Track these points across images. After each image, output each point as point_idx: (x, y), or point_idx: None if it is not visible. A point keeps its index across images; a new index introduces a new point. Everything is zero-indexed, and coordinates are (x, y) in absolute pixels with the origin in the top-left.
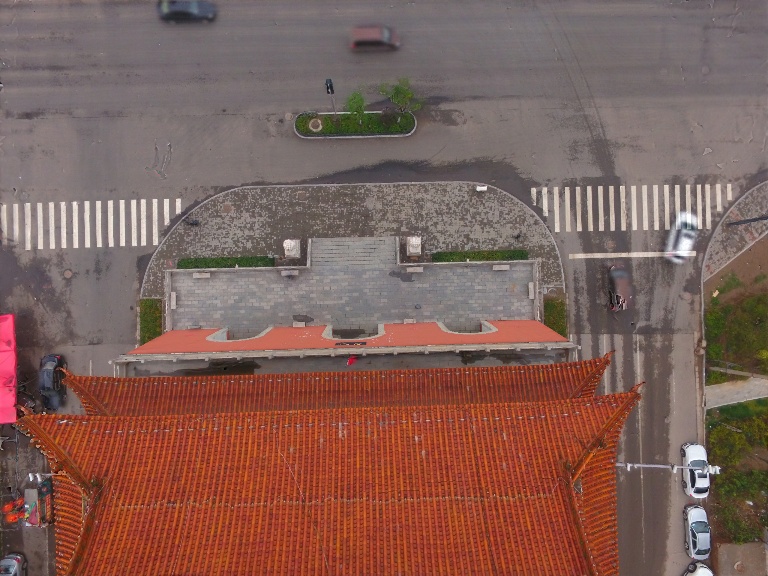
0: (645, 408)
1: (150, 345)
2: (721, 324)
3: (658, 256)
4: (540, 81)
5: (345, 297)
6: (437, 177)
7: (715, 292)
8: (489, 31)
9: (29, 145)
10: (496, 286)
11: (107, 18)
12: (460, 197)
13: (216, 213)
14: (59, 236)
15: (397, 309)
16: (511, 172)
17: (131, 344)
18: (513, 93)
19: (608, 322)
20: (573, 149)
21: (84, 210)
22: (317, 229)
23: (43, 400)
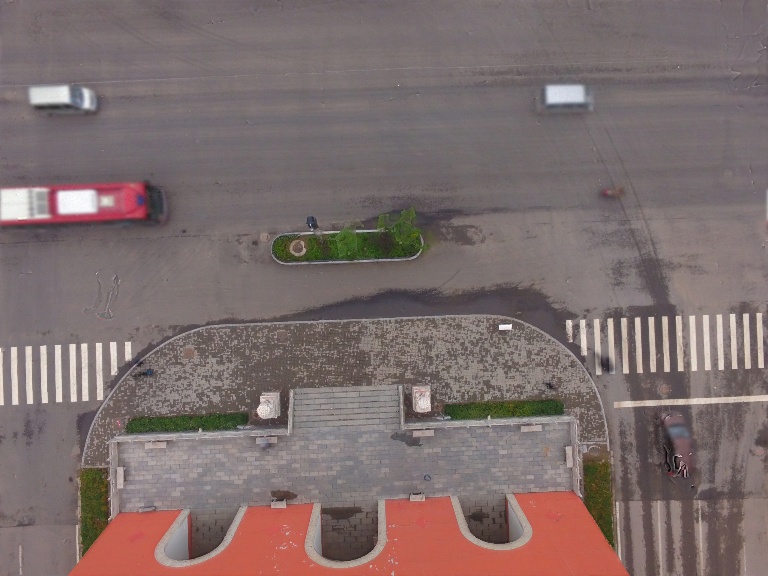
0: None
1: None
2: None
3: (723, 402)
4: (575, 188)
5: (336, 467)
6: (449, 309)
7: None
8: (512, 127)
9: None
10: (525, 449)
11: (37, 119)
12: (478, 334)
13: (175, 359)
14: None
15: (401, 481)
16: (541, 301)
17: (70, 524)
18: (542, 204)
19: (663, 485)
20: (617, 271)
21: (10, 358)
22: (301, 377)
23: None
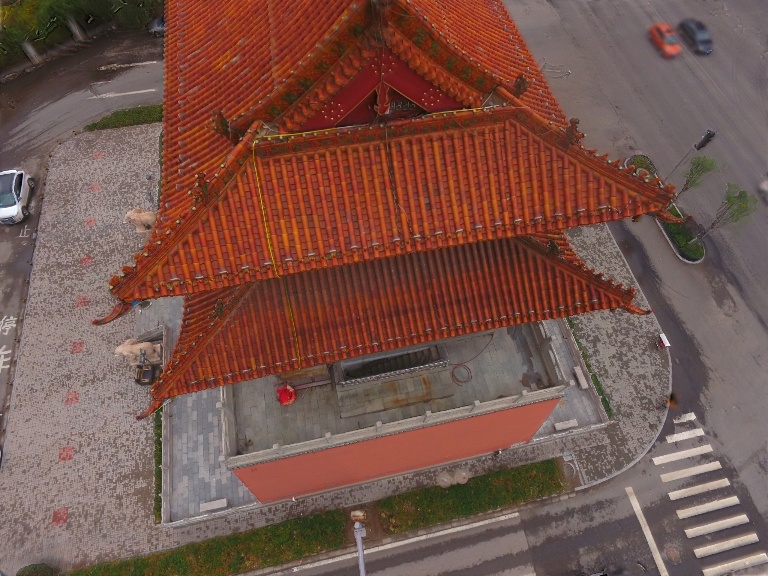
0: None
1: None
2: None
3: None
4: None
5: None
6: (649, 295)
7: None
8: None
9: (527, 3)
10: None
11: (648, 31)
12: (639, 324)
13: None
14: None
15: None
16: (699, 381)
17: None
18: None
19: None
20: None
21: None
22: None
23: None
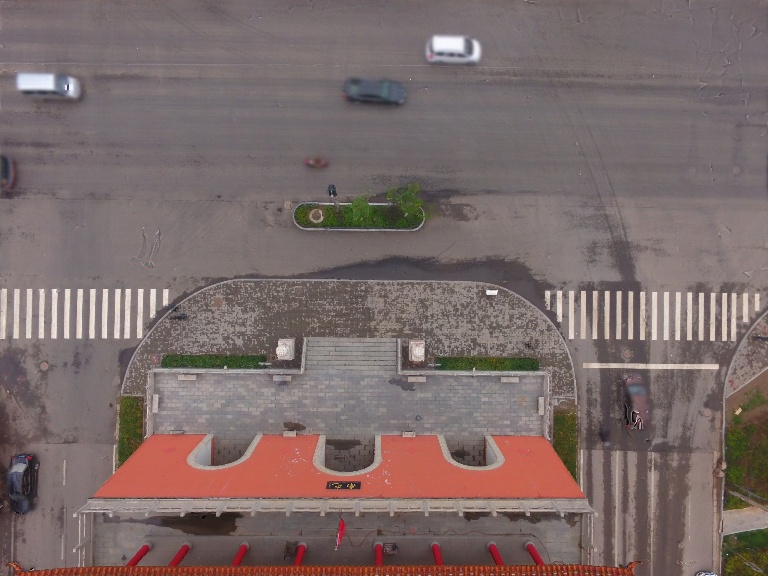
0: (658, 531)
1: (124, 472)
2: (743, 446)
3: (678, 368)
4: (559, 176)
5: (340, 405)
6: (445, 275)
7: (738, 410)
8: (507, 121)
9: (8, 226)
10: (503, 398)
11: (97, 93)
12: (468, 298)
13: (206, 307)
14: (36, 325)
15: (396, 419)
16: (524, 273)
17: (109, 444)
18: (530, 188)
19: (622, 438)
20: (592, 250)
21: (64, 298)
22: (314, 327)
23: (11, 503)
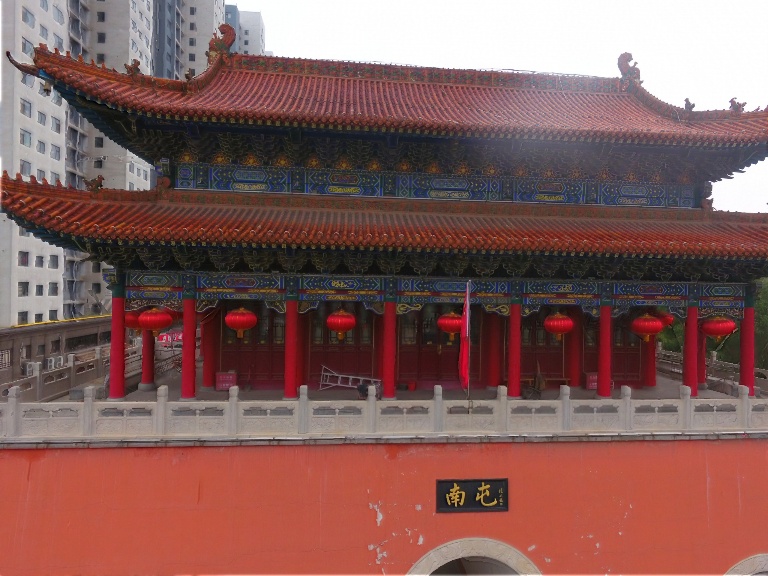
0: None
1: None
2: None
3: None
4: None
5: None
6: None
7: None
8: None
9: None
10: None
11: None
12: None
13: None
14: None
15: None
16: None
17: None
18: None
19: None
20: None
21: None
22: None
23: None
